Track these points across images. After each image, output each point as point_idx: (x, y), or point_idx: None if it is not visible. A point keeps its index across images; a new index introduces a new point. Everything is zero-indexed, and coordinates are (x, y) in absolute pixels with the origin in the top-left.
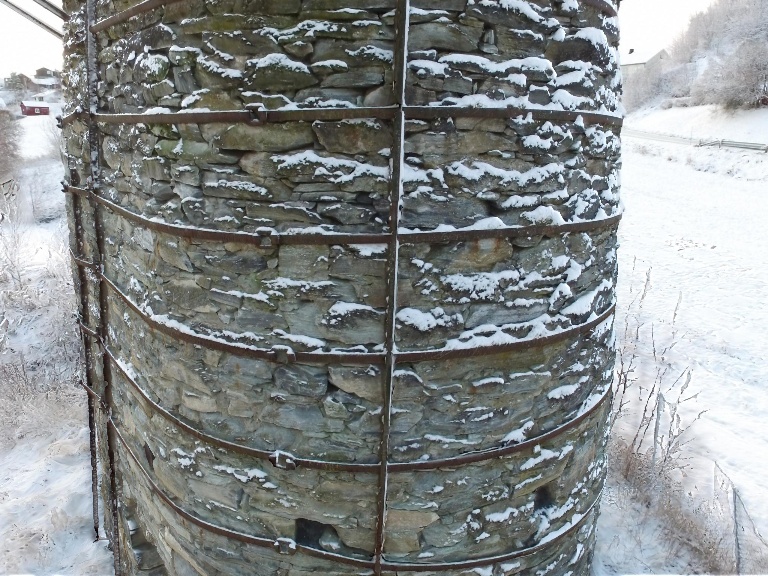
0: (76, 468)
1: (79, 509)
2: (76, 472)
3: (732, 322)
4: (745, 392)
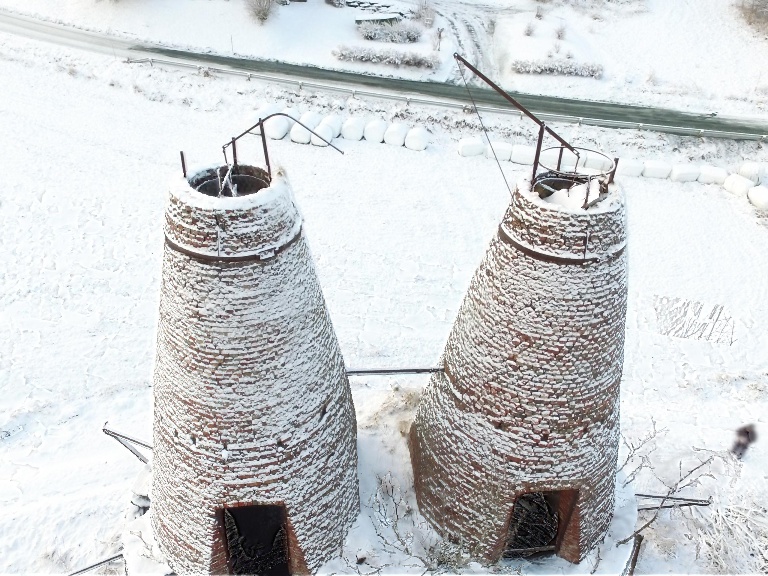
0: None
1: None
2: None
3: (359, 322)
4: (413, 383)
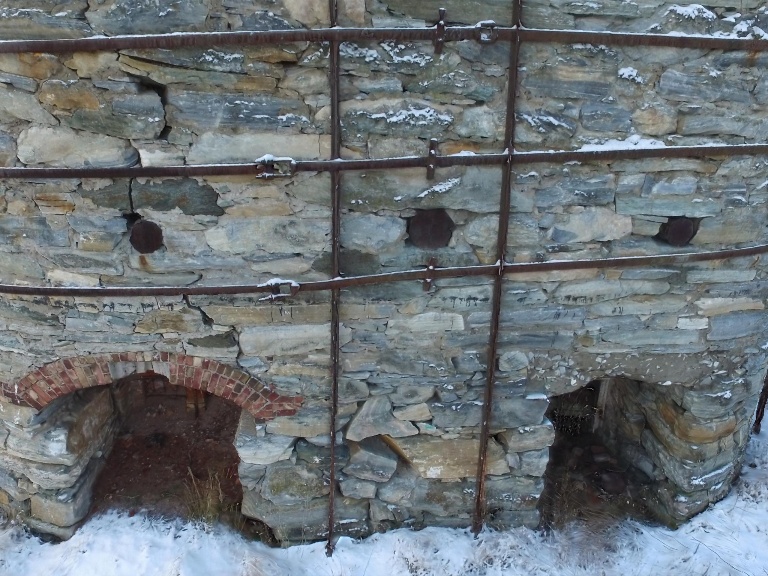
0: (58, 568)
1: (214, 570)
2: (79, 566)
3: None
4: None
